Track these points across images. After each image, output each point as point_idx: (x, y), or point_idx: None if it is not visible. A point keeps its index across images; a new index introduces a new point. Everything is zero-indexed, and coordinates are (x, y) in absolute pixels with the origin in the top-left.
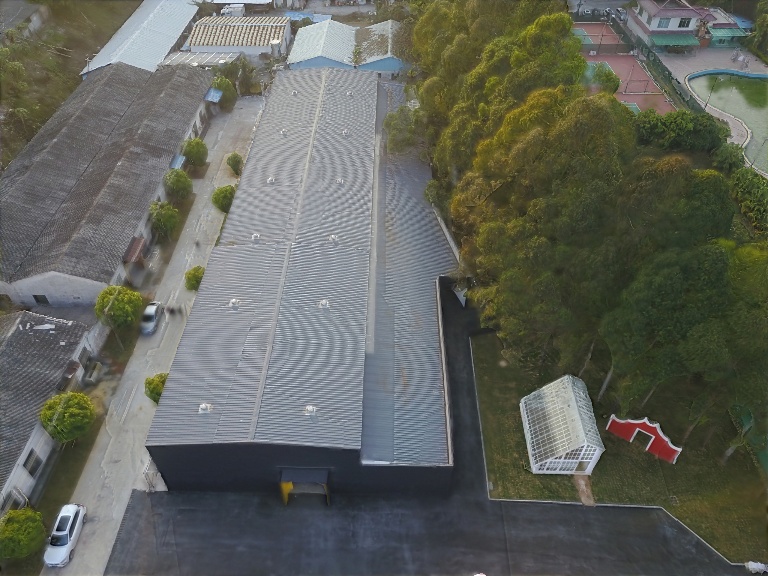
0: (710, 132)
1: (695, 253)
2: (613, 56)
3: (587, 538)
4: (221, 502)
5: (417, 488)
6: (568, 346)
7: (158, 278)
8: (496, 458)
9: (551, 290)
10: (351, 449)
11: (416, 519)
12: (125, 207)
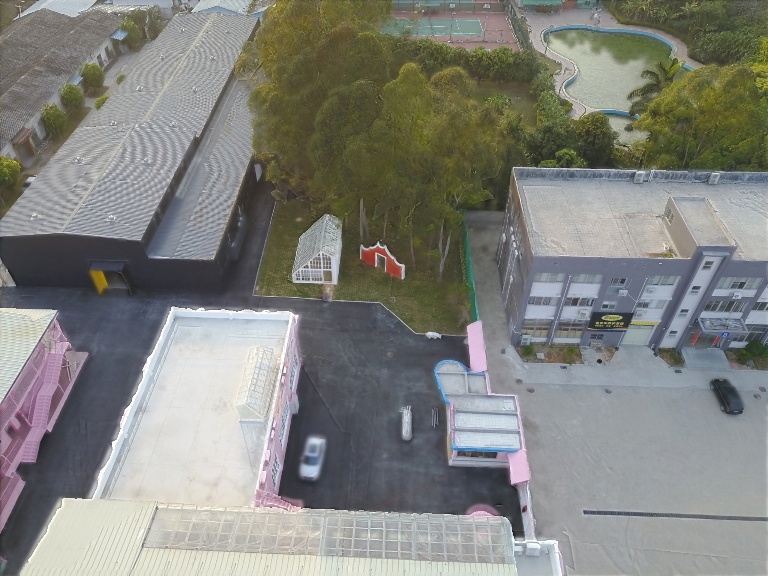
0: (528, 65)
1: (349, 87)
2: (487, 14)
3: (316, 318)
4: (53, 293)
5: (196, 283)
6: (313, 183)
7: (45, 162)
8: (268, 273)
9: (280, 129)
10: (133, 240)
11: (193, 304)
12: (21, 107)
